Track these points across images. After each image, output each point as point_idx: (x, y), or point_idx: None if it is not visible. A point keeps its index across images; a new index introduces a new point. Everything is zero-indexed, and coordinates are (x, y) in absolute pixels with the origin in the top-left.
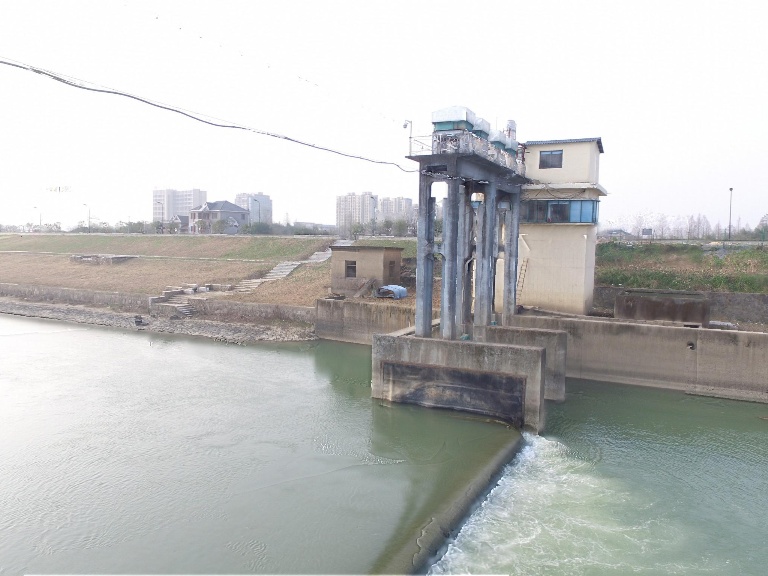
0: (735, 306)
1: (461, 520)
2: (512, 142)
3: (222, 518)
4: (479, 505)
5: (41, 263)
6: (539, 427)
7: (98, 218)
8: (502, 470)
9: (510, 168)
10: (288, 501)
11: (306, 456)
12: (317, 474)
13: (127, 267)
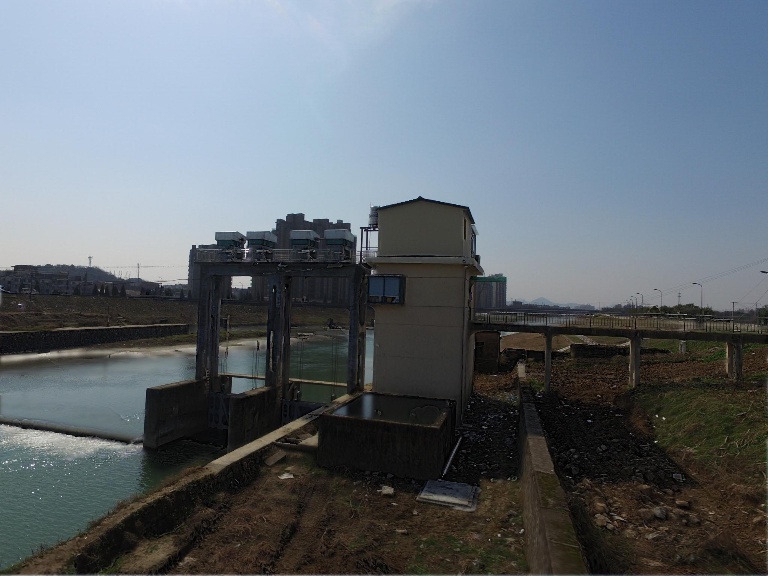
0: (526, 484)
1: (40, 427)
2: (328, 233)
3: (85, 405)
4: (54, 431)
5: (536, 335)
6: (146, 441)
7: (654, 304)
8: (89, 435)
9: (284, 260)
10: (90, 409)
11: (140, 409)
12: (116, 411)
13: (537, 340)
